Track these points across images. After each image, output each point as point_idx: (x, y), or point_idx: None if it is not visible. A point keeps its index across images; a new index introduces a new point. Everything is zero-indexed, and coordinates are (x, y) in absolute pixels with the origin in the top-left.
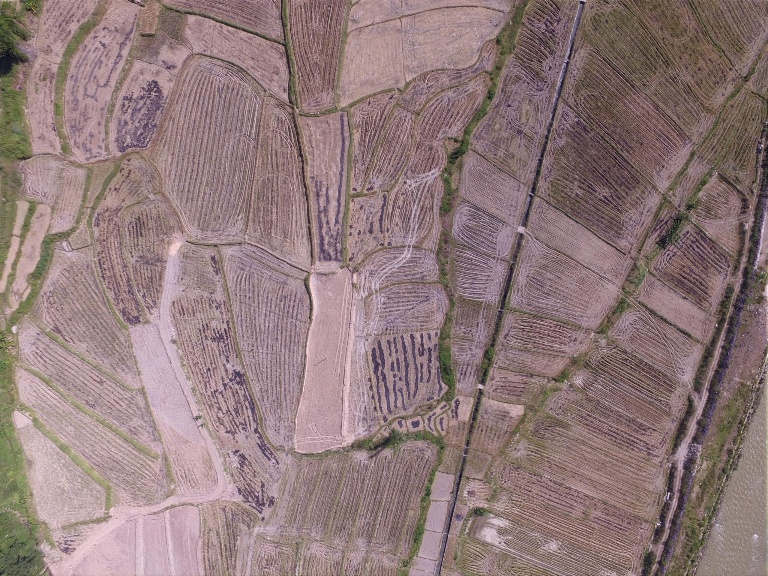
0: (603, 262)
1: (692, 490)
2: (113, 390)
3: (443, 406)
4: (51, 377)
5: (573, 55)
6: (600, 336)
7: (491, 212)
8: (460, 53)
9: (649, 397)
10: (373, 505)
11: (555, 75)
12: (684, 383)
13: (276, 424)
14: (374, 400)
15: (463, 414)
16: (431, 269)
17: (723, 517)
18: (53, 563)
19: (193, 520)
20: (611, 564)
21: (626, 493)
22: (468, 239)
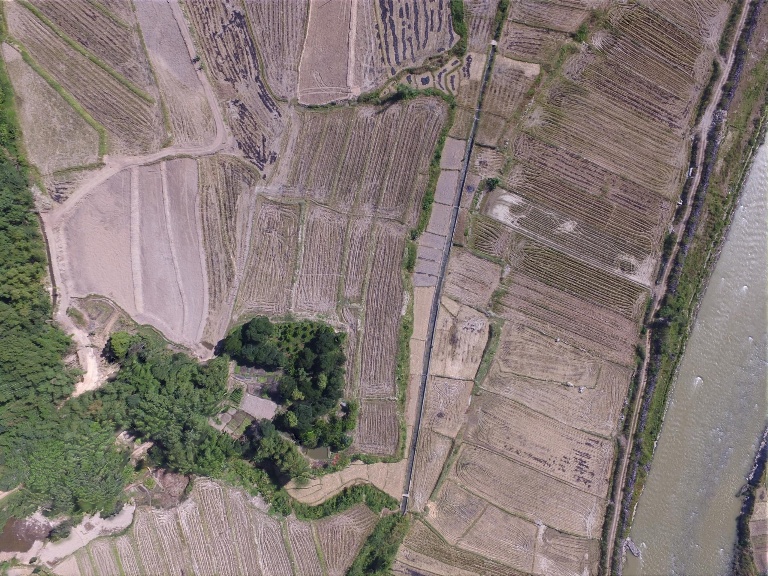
0: None
1: (716, 163)
2: (106, 26)
3: (454, 62)
4: (41, 10)
5: None
6: None
7: None
8: None
9: (672, 61)
10: (380, 167)
11: None
12: (709, 46)
13: (278, 72)
14: (382, 50)
15: (475, 73)
16: None
17: (748, 199)
18: (44, 210)
19: (191, 174)
20: (629, 247)
21: (646, 168)
22: None
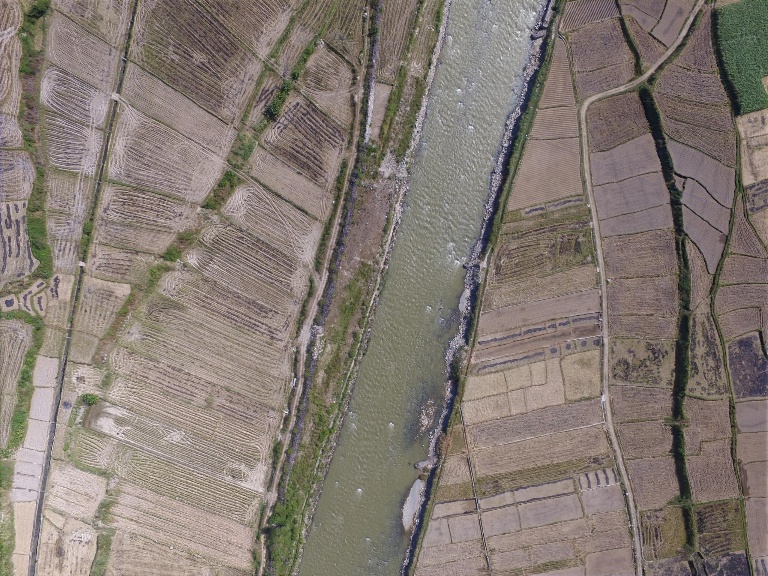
0: (205, 132)
1: (317, 375)
2: None
3: (40, 284)
4: None
5: None
6: (210, 212)
7: (82, 77)
8: None
9: (268, 277)
10: None
11: None
12: (304, 263)
13: None
14: None
15: (64, 293)
16: (13, 135)
17: (356, 405)
18: None
19: None
20: (239, 455)
21: (250, 379)
22: (58, 105)
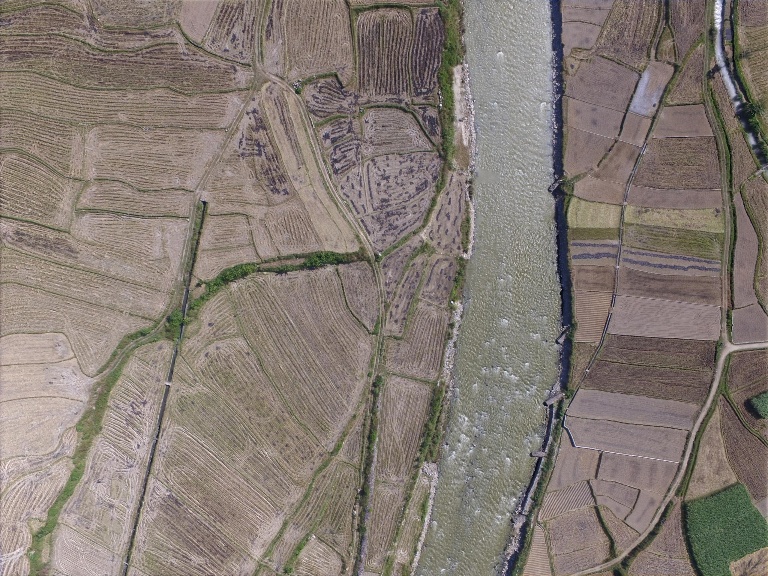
0: None
1: None
2: None
3: None
4: None
5: (161, 434)
6: None
7: None
8: (40, 440)
9: None
10: None
11: (144, 453)
12: None
13: None
14: None
15: None
16: None
17: None
18: None
19: None
20: None
21: None
22: None
